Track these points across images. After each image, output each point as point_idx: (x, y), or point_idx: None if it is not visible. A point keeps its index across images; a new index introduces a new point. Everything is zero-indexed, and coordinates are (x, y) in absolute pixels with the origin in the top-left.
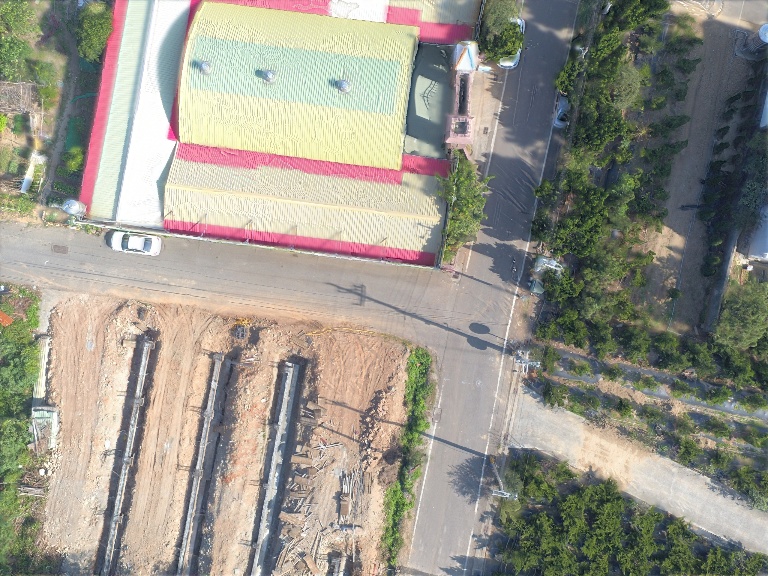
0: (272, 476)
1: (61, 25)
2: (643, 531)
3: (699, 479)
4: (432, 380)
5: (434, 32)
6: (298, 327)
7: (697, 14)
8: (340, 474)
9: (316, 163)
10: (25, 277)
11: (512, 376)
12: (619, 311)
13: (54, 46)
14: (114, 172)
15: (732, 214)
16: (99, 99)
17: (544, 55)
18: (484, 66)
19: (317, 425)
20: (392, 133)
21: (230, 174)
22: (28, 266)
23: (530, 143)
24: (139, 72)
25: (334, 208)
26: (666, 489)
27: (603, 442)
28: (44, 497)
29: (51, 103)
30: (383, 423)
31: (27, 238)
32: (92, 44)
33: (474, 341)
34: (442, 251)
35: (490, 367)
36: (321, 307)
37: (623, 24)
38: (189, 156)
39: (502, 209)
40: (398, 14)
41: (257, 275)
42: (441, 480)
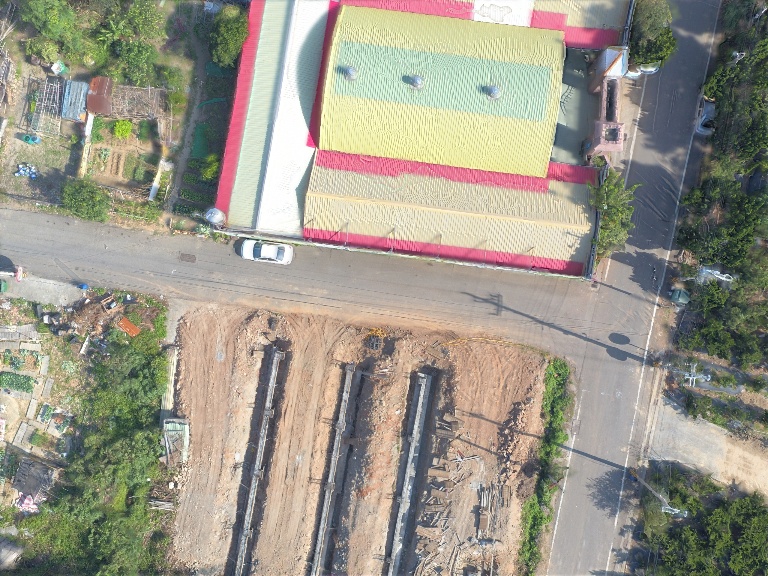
0: (406, 489)
1: (186, 28)
2: None
3: None
4: (570, 391)
5: (579, 36)
6: (433, 337)
7: None
8: (478, 487)
9: (460, 170)
10: (152, 286)
11: (652, 387)
12: (764, 321)
13: (183, 50)
14: (250, 179)
15: None
16: (234, 105)
17: (684, 60)
18: None
19: (455, 437)
20: (542, 140)
21: (368, 181)
22: (155, 275)
23: (670, 150)
24: (278, 77)
25: (481, 217)
26: None
27: (746, 454)
28: (174, 511)
29: (179, 108)
30: (522, 435)
31: (154, 246)
32: (228, 48)
33: (614, 352)
34: (593, 261)
35: (630, 378)
36: (457, 317)
37: None
38: (330, 163)
39: (642, 217)
40: (542, 18)
41: (391, 284)
42: (580, 493)
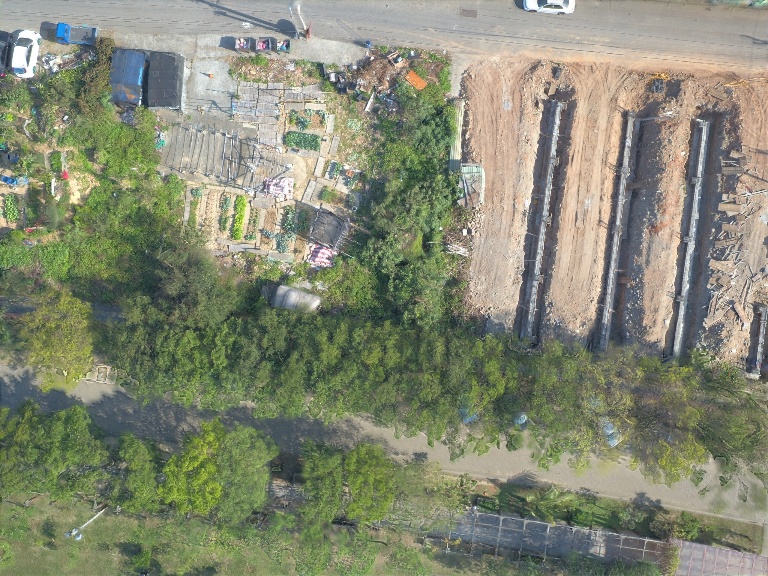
0: None
1: None
2: None
3: None
4: None
5: None
6: (715, 79)
7: None
8: (767, 220)
9: None
10: (434, 42)
11: None
12: None
13: None
14: None
15: None
16: None
17: None
18: None
19: (744, 172)
20: None
21: None
22: (437, 31)
23: None
24: None
25: None
26: None
27: None
28: (468, 257)
29: None
30: None
31: (434, 4)
32: None
33: None
34: None
35: None
36: (737, 59)
37: None
38: None
39: None
40: None
41: (671, 30)
42: None
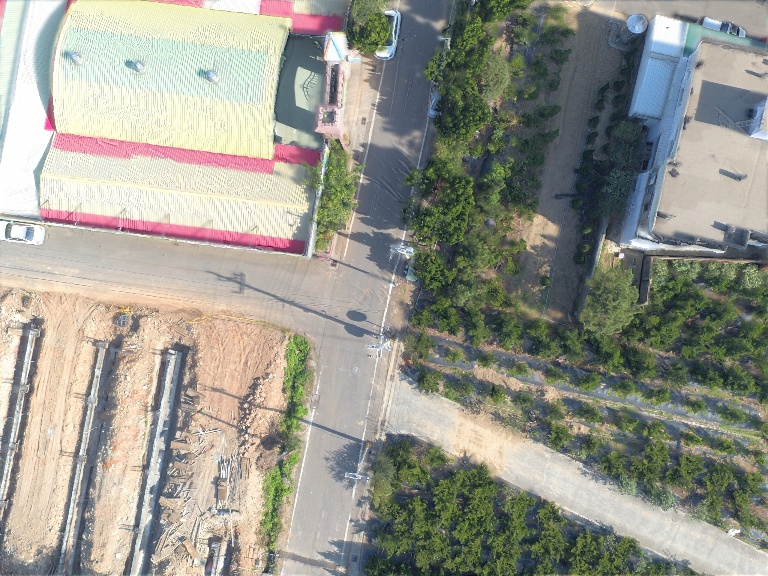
0: (154, 462)
1: None
2: (514, 515)
3: (572, 464)
4: (310, 367)
5: (306, 23)
6: (179, 315)
7: (570, 5)
8: (219, 460)
9: (189, 153)
10: None
11: (389, 363)
12: (492, 298)
13: None
14: None
15: (599, 202)
16: None
17: (421, 46)
18: (362, 57)
19: (196, 411)
20: (260, 123)
21: (108, 164)
22: None
23: (407, 133)
24: (16, 63)
25: (205, 197)
26: (539, 474)
27: (477, 428)
28: None
29: None
30: (261, 409)
31: None
32: None
33: (351, 328)
34: (309, 239)
35: (367, 354)
36: (201, 295)
37: (489, 15)
38: (65, 146)
39: (379, 198)
40: (271, 6)
41: (139, 264)
42: (319, 466)
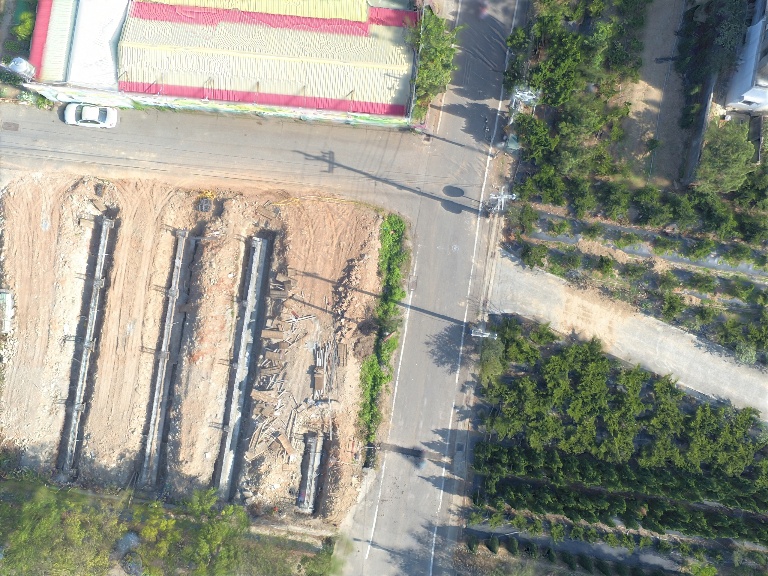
0: (242, 355)
1: None
2: (630, 391)
3: (685, 337)
4: (406, 247)
5: None
6: (264, 197)
7: None
8: (313, 347)
9: (276, 17)
10: None
11: (489, 240)
12: (596, 166)
13: None
14: (64, 35)
15: (707, 58)
16: None
17: None
18: None
19: (287, 297)
20: None
21: (187, 35)
22: None
23: None
24: None
25: (296, 61)
26: (652, 349)
27: (585, 303)
28: None
29: None
30: (357, 292)
31: None
32: None
33: (448, 205)
34: (411, 100)
35: (466, 231)
36: (288, 176)
37: None
38: (142, 13)
39: (472, 68)
40: None
41: (219, 145)
42: (419, 351)
